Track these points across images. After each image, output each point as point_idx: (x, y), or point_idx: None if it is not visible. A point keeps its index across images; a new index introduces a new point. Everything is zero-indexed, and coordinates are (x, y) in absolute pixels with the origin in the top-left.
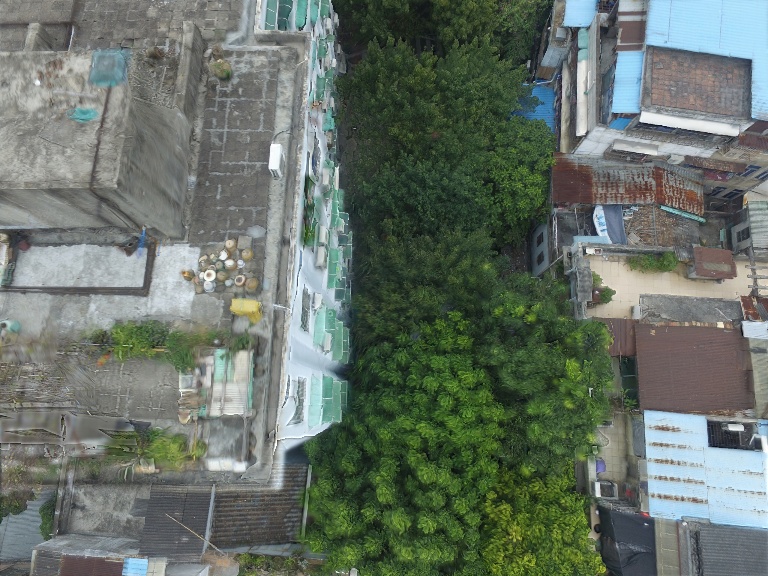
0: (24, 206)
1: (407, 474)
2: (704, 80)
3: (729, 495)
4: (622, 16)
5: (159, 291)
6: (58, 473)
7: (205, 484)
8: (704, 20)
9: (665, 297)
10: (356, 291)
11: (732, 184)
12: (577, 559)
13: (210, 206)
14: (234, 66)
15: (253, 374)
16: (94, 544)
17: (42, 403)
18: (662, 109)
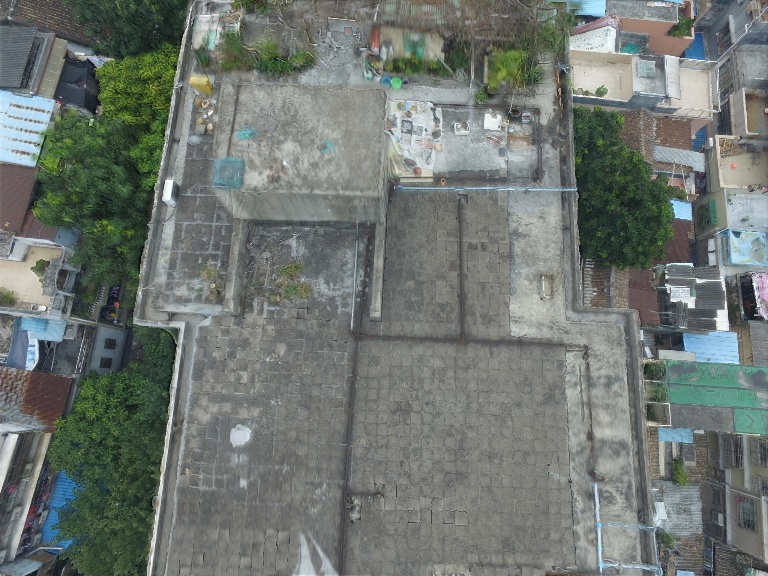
0: None
1: None
2: None
3: None
4: None
5: None
6: None
7: None
8: None
9: None
10: None
11: None
12: None
13: None
14: (204, 286)
15: None
16: None
17: None
18: None
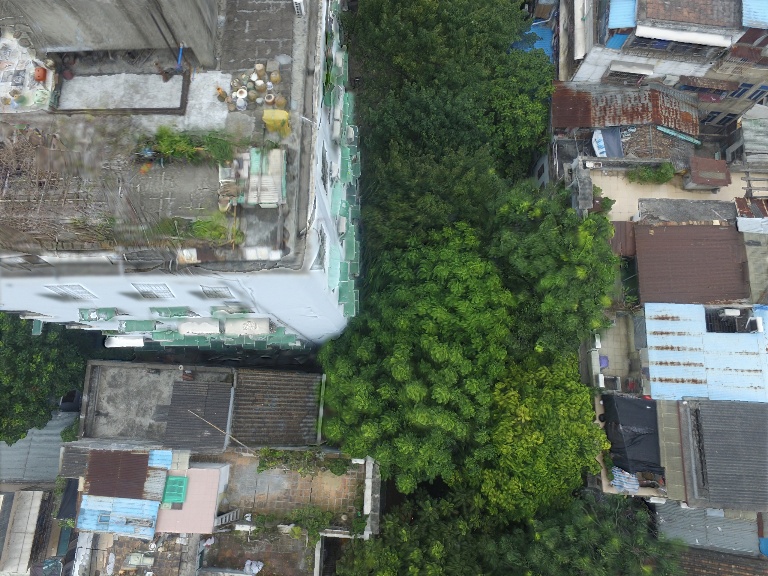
0: (75, 9)
1: (420, 359)
2: None
3: (727, 375)
4: None
5: (195, 111)
6: (82, 380)
7: (225, 384)
8: None
9: (663, 201)
10: (365, 210)
11: (726, 107)
12: (583, 433)
13: (239, 39)
14: None
15: (286, 169)
16: (119, 442)
17: (82, 243)
18: (657, 22)
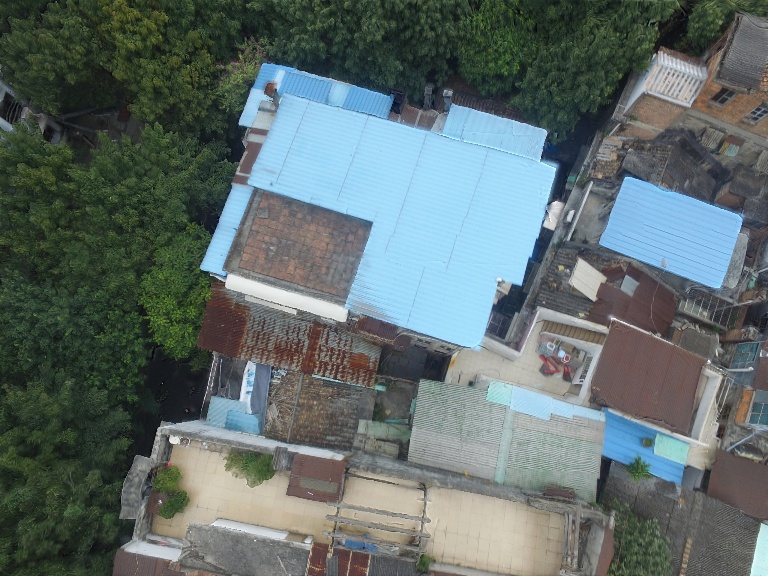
0: None
1: None
2: (316, 240)
3: None
4: (252, 134)
5: None
6: None
7: None
8: (331, 157)
9: (218, 531)
10: None
11: (426, 346)
12: None
13: None
14: None
15: None
16: None
17: None
18: (248, 276)
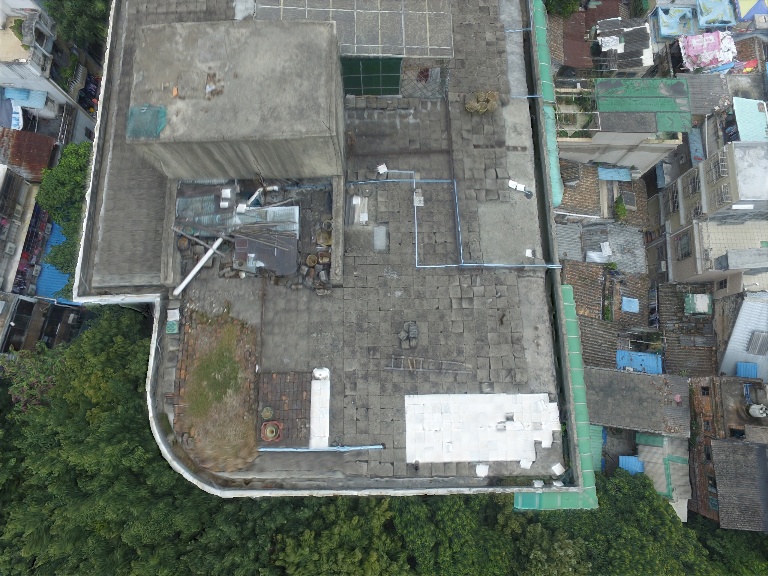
0: None
1: None
2: None
3: None
4: None
5: None
6: None
7: None
8: None
9: None
10: None
11: None
12: None
13: None
14: None
15: None
16: None
17: None
18: None
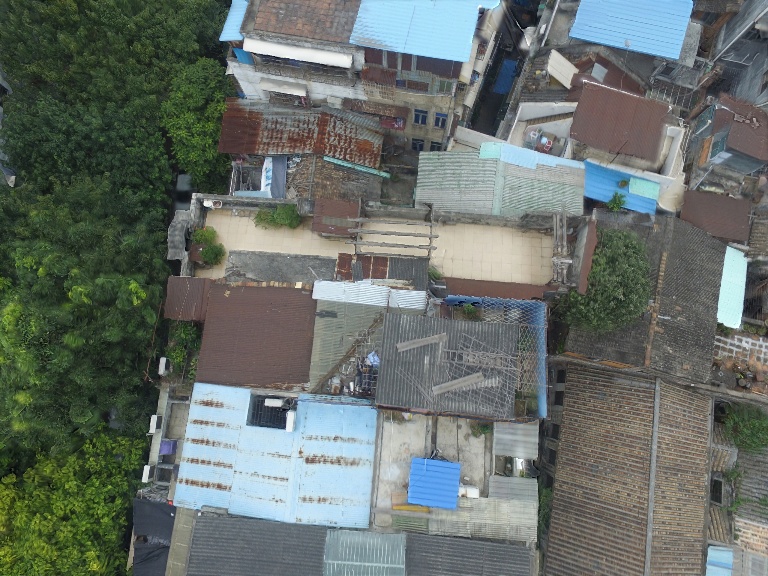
0: None
1: None
2: (319, 2)
3: (253, 481)
4: None
5: None
6: None
7: None
8: None
9: (255, 254)
10: None
11: (423, 135)
12: (45, 554)
13: None
14: None
15: None
16: None
17: None
18: (263, 35)
